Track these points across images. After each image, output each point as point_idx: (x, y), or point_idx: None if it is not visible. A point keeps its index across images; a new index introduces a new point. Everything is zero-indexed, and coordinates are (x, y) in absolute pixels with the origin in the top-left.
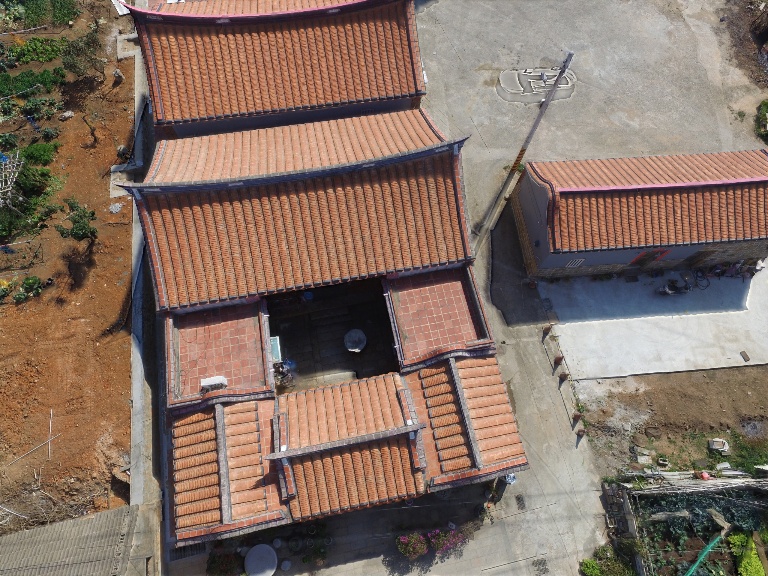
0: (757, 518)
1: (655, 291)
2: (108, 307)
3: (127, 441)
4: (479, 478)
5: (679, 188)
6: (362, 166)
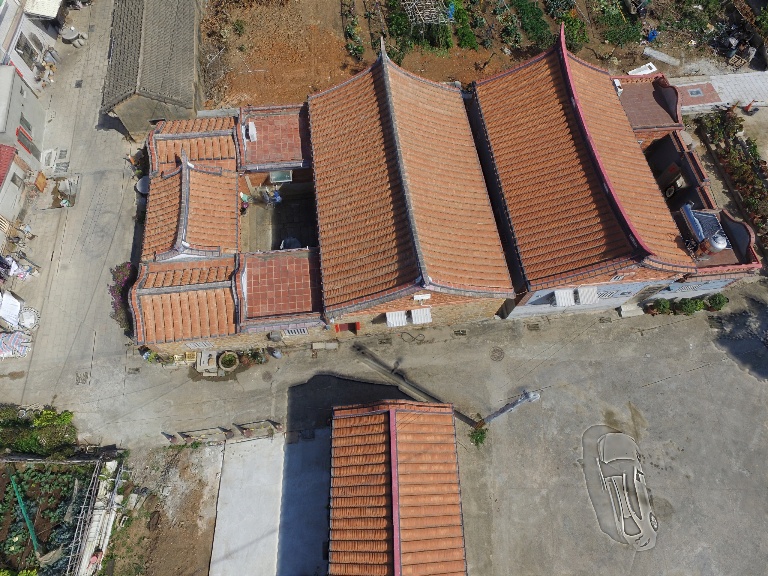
0: None
1: (306, 575)
2: None
3: None
4: None
5: None
6: None
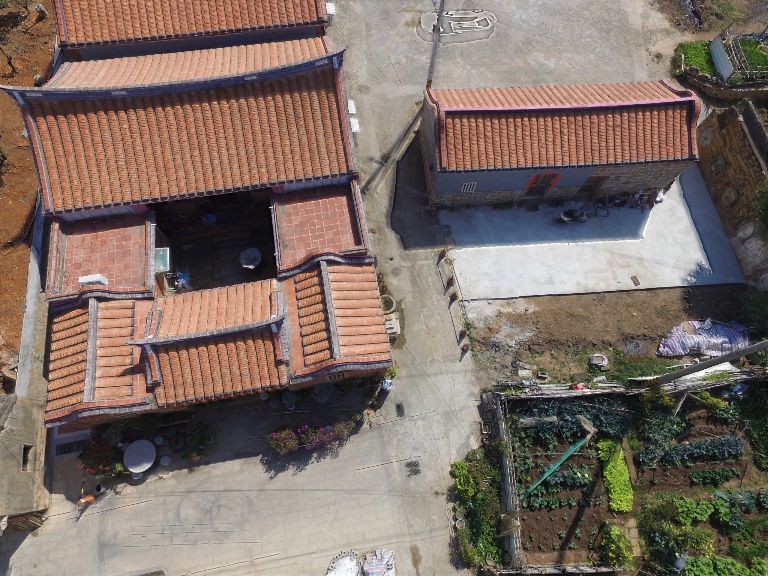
0: (625, 425)
1: (553, 219)
2: (11, 222)
3: (18, 342)
4: (335, 368)
5: (565, 110)
6: (244, 79)
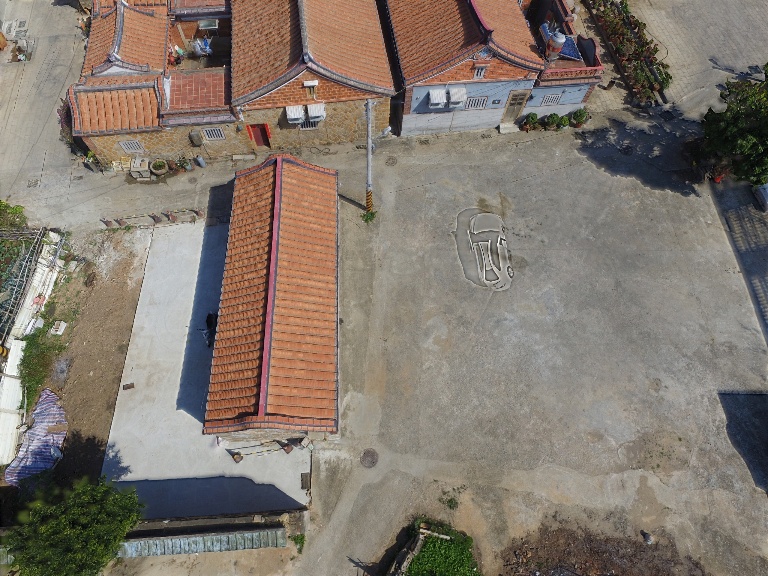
0: None
1: None
2: None
3: None
4: None
5: None
6: None
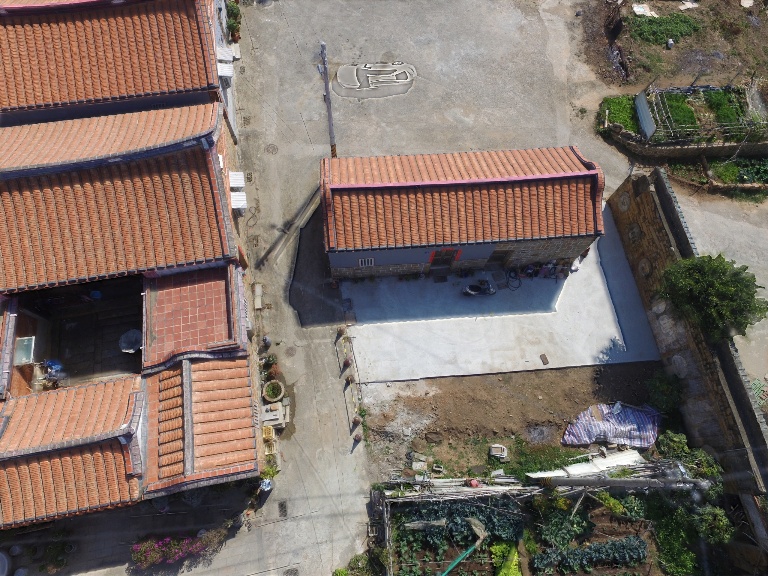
0: (520, 528)
1: (461, 292)
2: None
3: None
4: (186, 485)
5: (462, 185)
6: (108, 161)
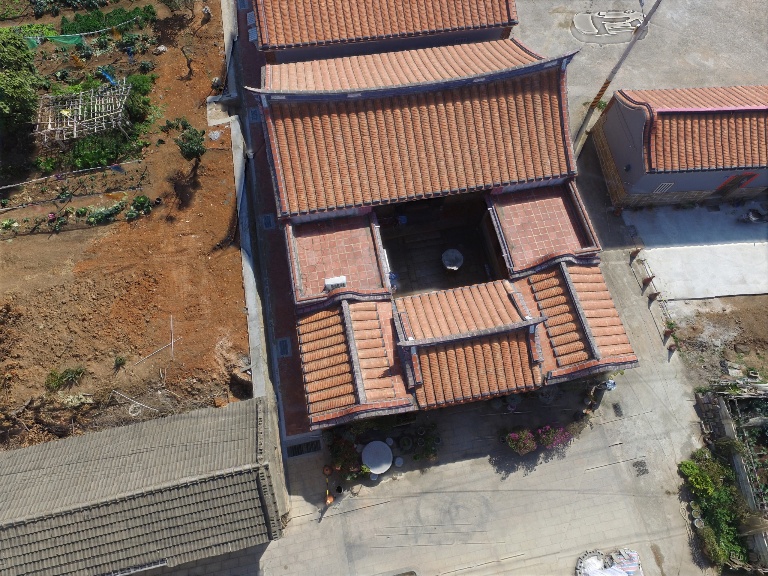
0: None
1: (737, 219)
2: (216, 224)
3: (245, 344)
4: (598, 369)
5: None
6: (473, 81)
